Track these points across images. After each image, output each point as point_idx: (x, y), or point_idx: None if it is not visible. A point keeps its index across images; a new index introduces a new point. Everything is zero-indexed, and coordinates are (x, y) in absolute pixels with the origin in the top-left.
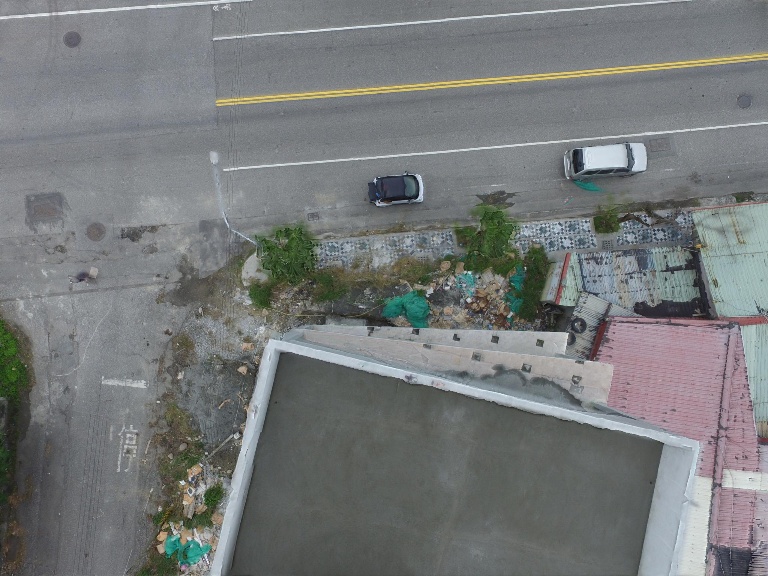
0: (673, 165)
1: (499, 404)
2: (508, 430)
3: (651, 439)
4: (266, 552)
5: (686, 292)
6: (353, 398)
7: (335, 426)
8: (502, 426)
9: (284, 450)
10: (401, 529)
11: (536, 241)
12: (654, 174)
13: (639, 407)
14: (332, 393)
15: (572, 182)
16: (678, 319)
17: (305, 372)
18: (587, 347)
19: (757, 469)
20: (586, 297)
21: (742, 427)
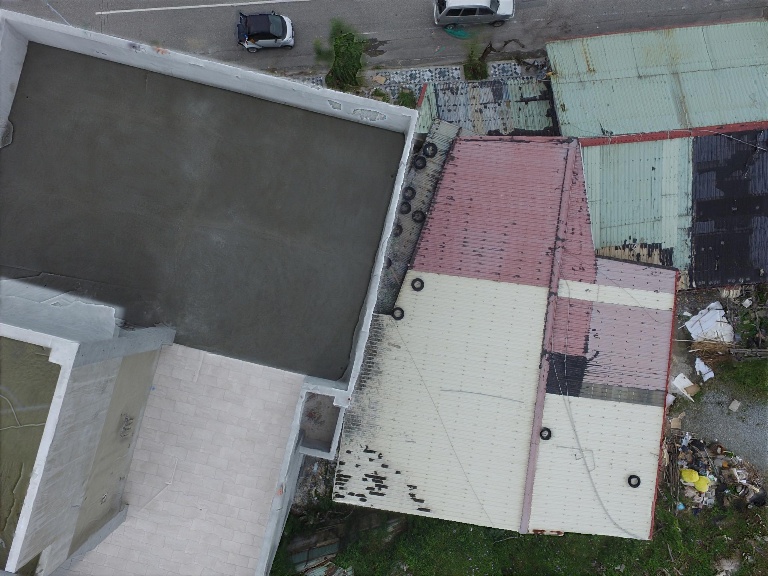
0: (543, 15)
1: (228, 78)
2: (254, 125)
3: (393, 134)
4: (4, 228)
5: (539, 122)
6: (103, 93)
7: (84, 120)
8: (248, 121)
9: (33, 142)
10: (145, 216)
11: (406, 87)
12: (525, 24)
13: (481, 221)
14: (82, 88)
15: (443, 31)
16: (520, 136)
17: (56, 68)
18: (437, 170)
19: (594, 281)
20: (438, 123)
21: (580, 240)
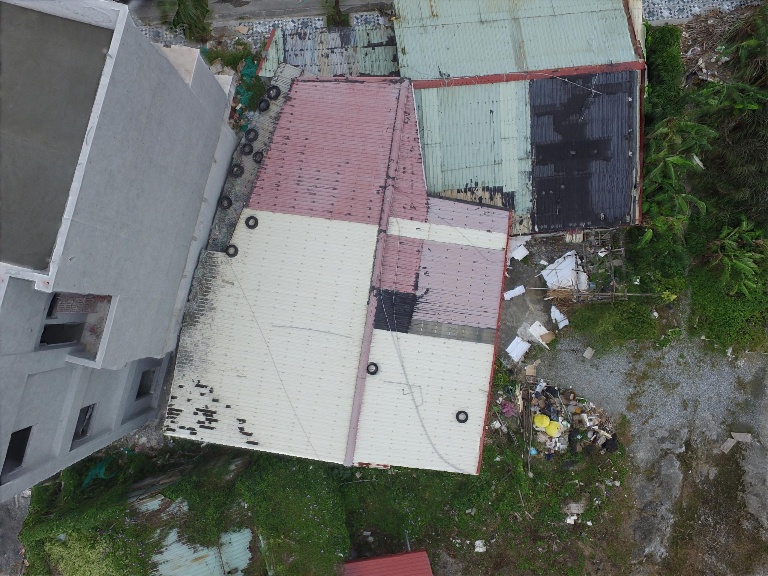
0: None
1: None
2: None
3: None
4: None
5: (385, 67)
6: None
7: None
8: None
9: None
10: None
11: (268, 37)
12: None
13: (315, 161)
14: None
15: None
16: (355, 77)
17: None
18: None
19: (426, 220)
20: (283, 67)
21: (411, 179)
